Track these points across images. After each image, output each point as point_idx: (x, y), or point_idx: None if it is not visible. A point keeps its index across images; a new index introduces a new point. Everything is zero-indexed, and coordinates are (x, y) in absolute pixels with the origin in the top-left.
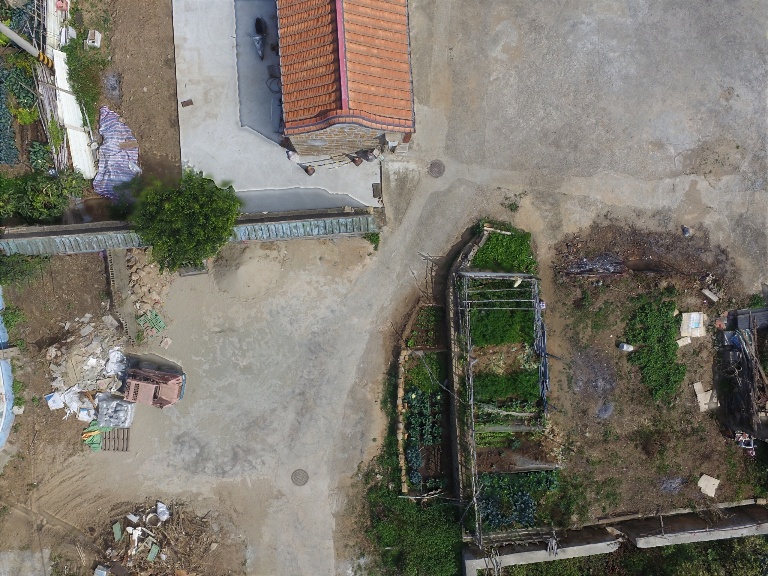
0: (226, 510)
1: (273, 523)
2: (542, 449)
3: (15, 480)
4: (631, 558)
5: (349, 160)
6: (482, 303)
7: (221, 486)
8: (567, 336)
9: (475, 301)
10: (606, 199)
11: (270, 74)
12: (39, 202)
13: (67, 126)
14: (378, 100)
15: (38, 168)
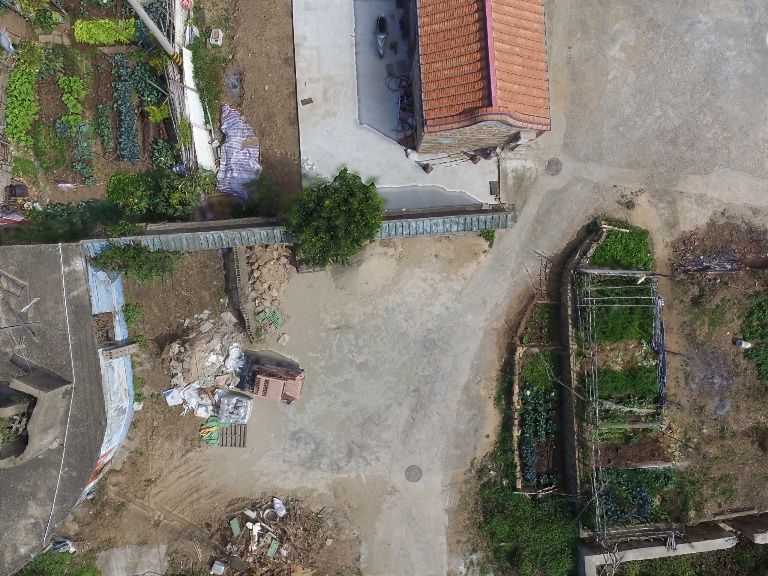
0: (340, 506)
1: (387, 519)
2: (660, 445)
3: (133, 476)
4: (743, 554)
5: (467, 158)
6: (600, 300)
7: (336, 482)
8: (684, 333)
9: (596, 298)
10: (723, 197)
11: (389, 73)
12: (175, 199)
13: (192, 124)
14: (520, 98)
15: (161, 165)
